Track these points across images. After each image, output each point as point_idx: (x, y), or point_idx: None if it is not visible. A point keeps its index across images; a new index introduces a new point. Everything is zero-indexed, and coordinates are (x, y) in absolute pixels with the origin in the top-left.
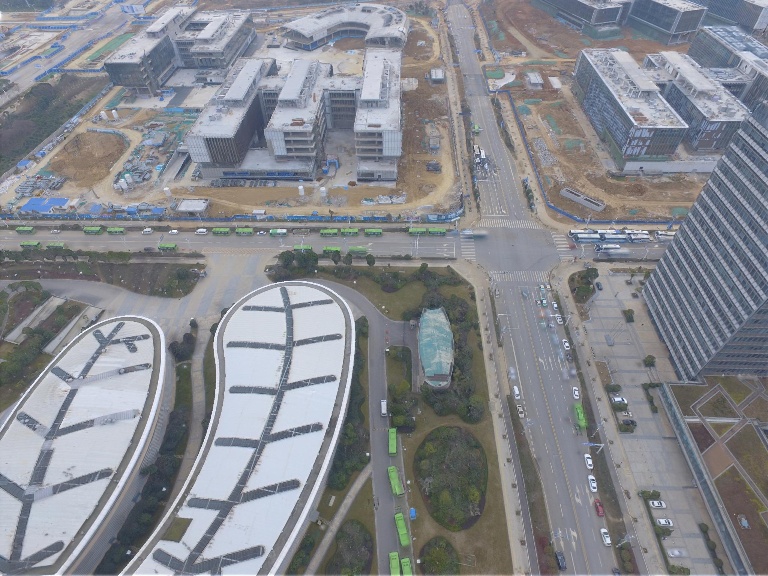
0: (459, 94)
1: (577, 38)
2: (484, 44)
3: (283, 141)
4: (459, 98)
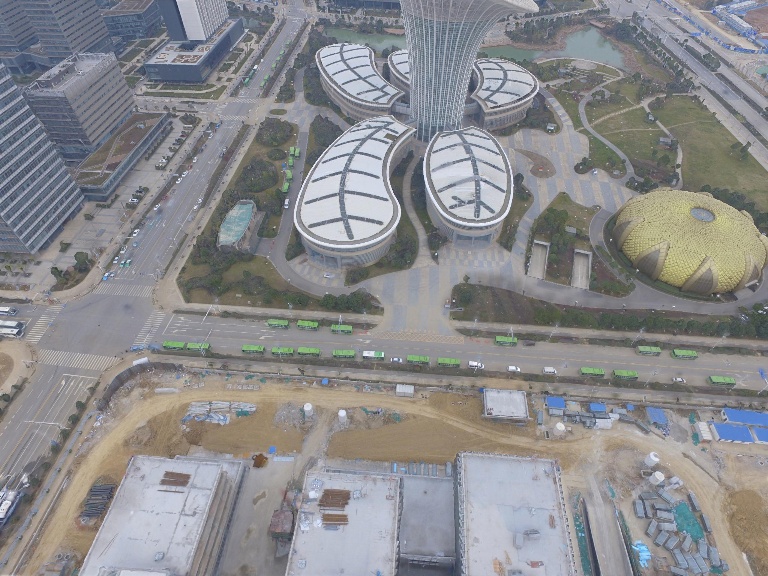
0: None
1: None
2: None
3: None
4: None
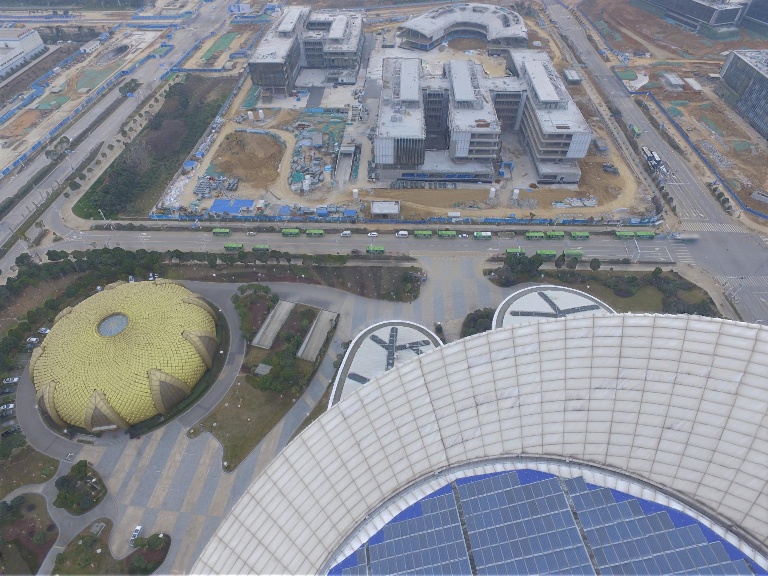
0: (600, 95)
1: (695, 39)
2: (601, 45)
3: (468, 142)
4: (602, 99)
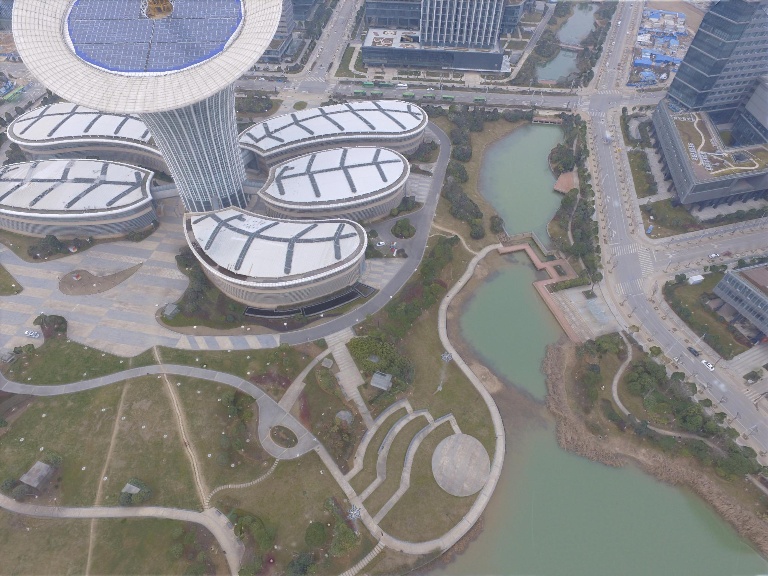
0: None
1: None
2: None
3: None
4: None
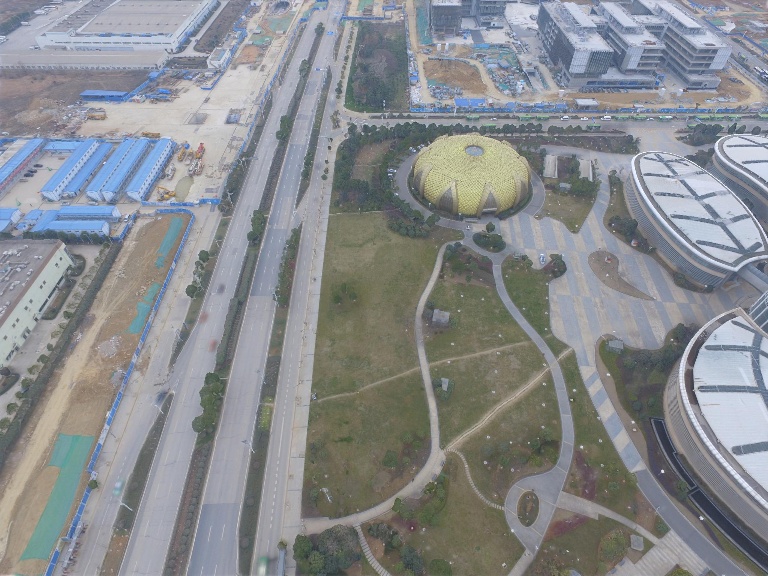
0: None
1: None
2: (686, 2)
3: (640, 57)
4: None
